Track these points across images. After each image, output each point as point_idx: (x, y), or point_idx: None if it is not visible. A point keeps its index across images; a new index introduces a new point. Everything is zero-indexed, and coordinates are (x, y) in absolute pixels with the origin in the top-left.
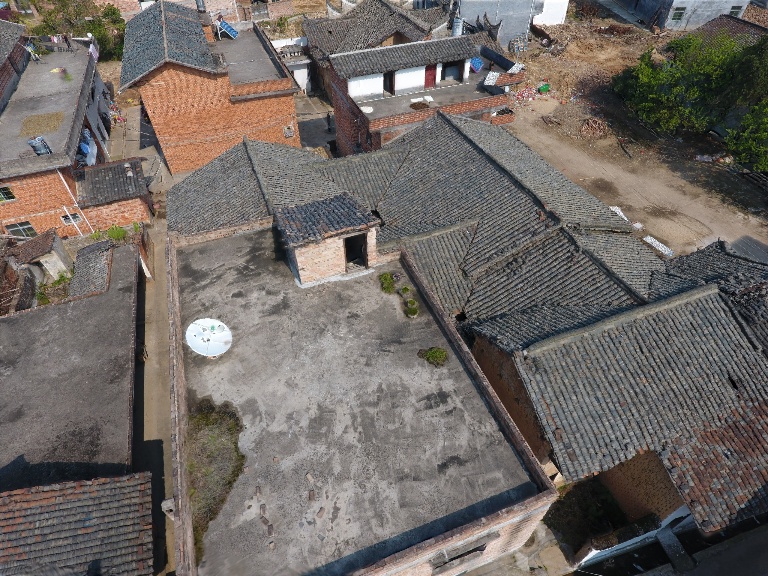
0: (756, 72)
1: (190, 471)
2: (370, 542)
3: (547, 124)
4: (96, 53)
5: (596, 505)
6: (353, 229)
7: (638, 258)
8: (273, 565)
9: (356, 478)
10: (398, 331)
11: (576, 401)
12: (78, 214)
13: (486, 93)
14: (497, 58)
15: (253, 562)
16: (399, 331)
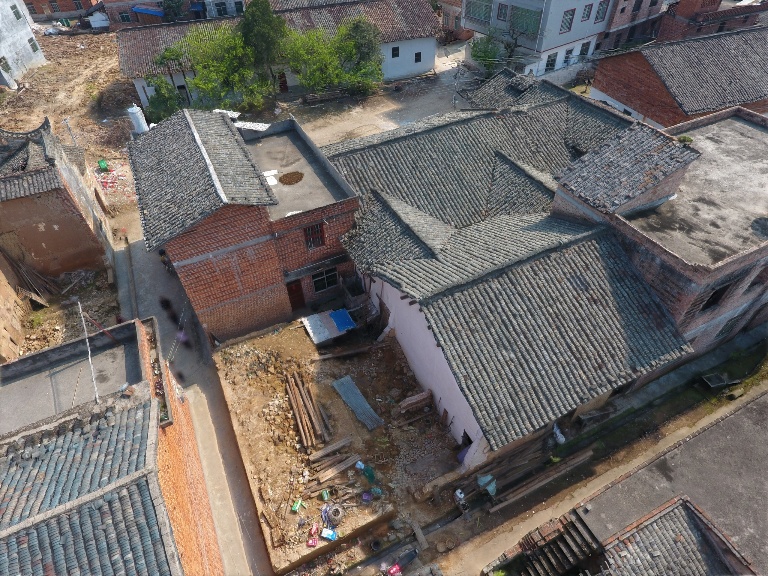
0: (270, 36)
1: None
2: None
3: None
4: None
5: None
6: None
7: None
8: None
9: None
10: None
11: None
12: None
13: (263, 139)
14: None
15: None
16: None
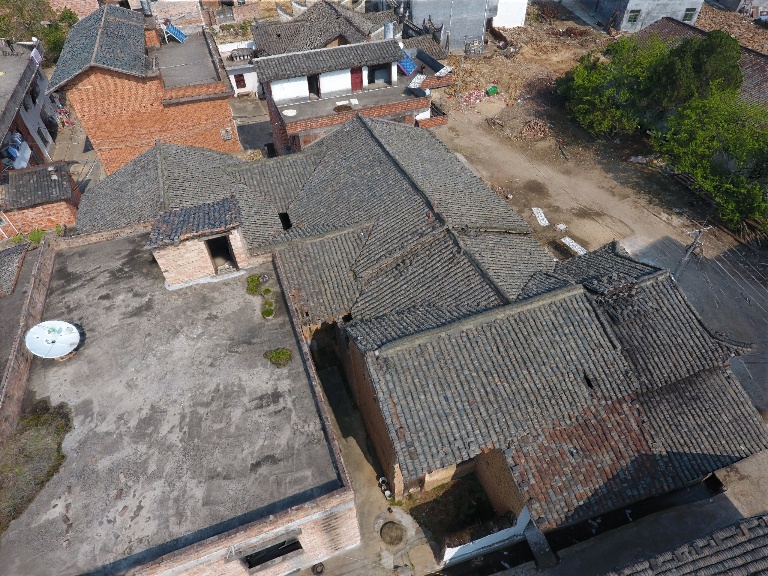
0: (678, 74)
1: (2, 471)
2: (163, 540)
3: (490, 126)
4: (39, 57)
5: (470, 503)
6: (210, 232)
7: (527, 259)
8: (62, 563)
9: (167, 477)
10: (251, 332)
11: (424, 400)
12: (2, 217)
13: (412, 96)
14: (430, 61)
15: (43, 560)
16: (252, 332)
